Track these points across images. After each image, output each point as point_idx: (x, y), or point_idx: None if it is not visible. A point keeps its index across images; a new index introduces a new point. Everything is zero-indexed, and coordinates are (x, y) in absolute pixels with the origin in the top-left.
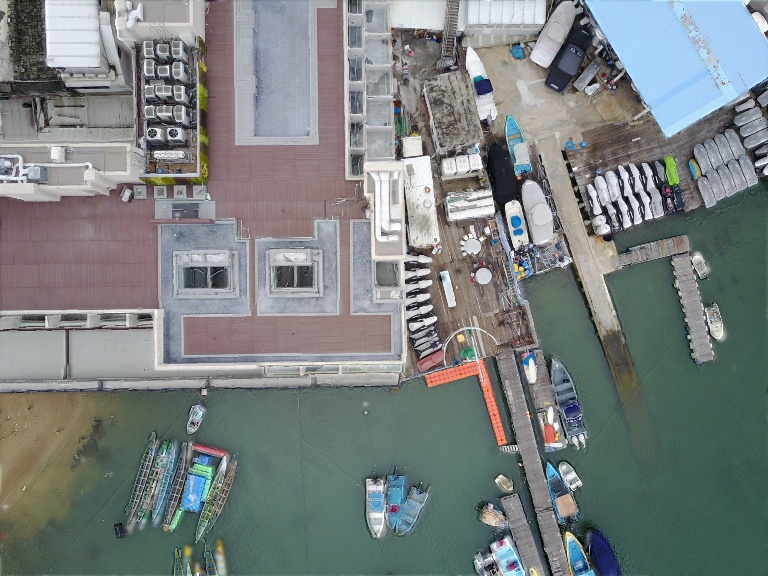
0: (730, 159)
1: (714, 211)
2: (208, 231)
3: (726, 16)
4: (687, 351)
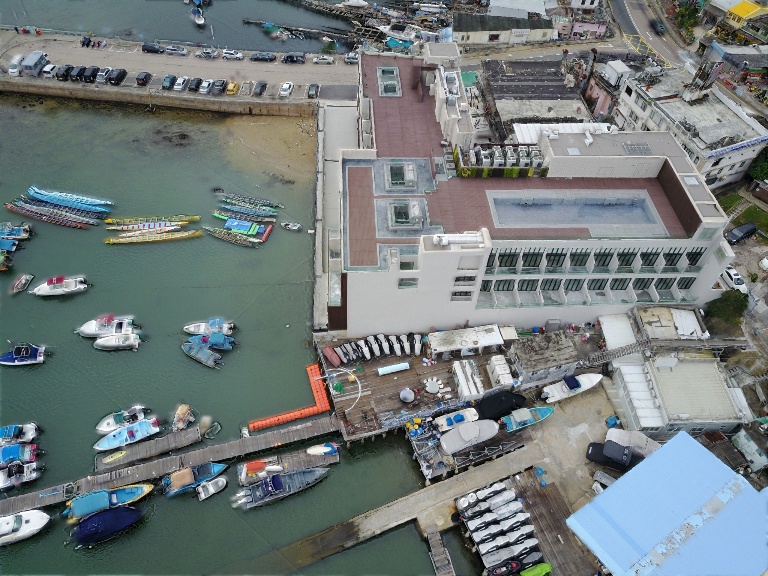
0: None
1: None
2: (428, 178)
3: None
4: None
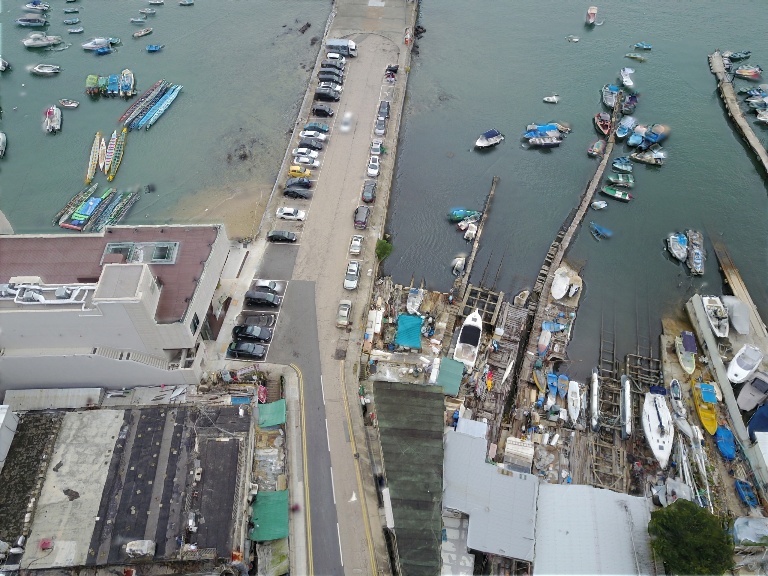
0: None
1: None
2: None
3: None
4: None
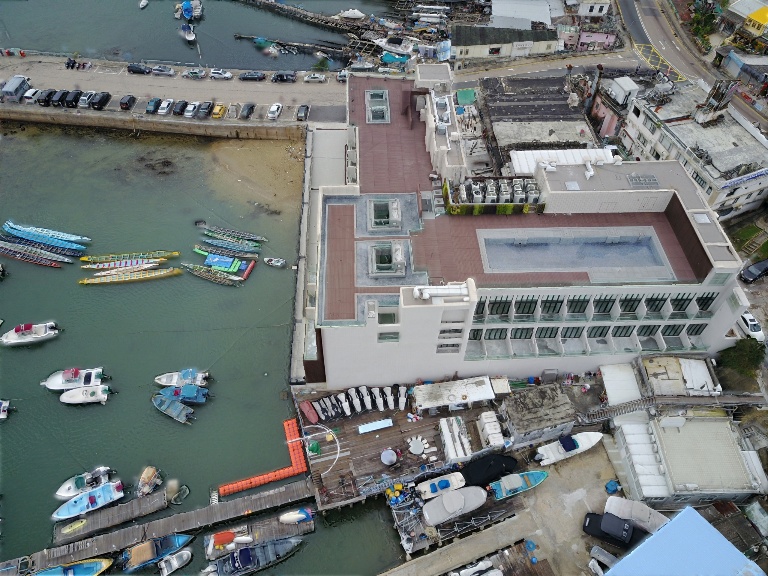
0: None
1: None
2: (414, 216)
3: None
4: None
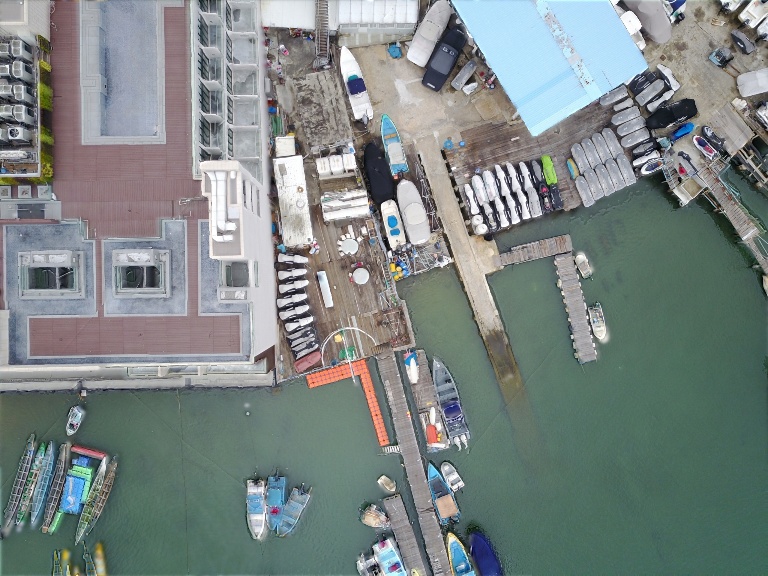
0: (608, 158)
1: (599, 210)
2: (54, 231)
3: (591, 15)
4: (570, 351)
